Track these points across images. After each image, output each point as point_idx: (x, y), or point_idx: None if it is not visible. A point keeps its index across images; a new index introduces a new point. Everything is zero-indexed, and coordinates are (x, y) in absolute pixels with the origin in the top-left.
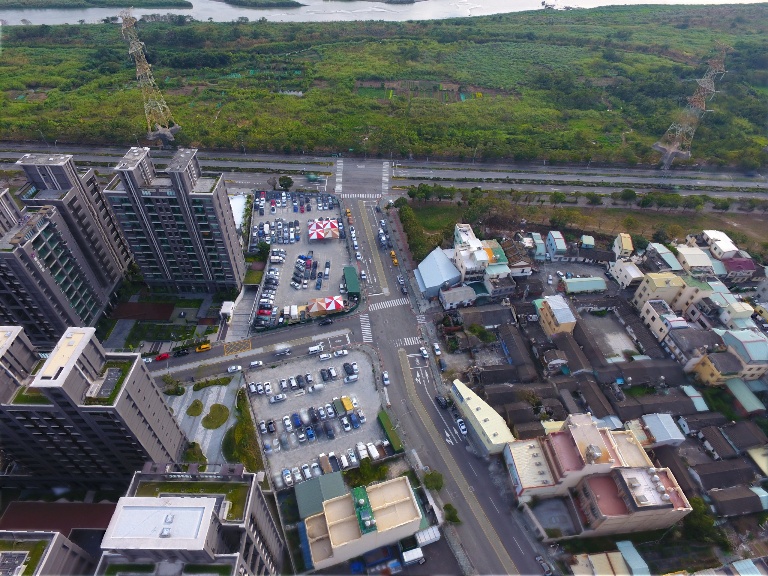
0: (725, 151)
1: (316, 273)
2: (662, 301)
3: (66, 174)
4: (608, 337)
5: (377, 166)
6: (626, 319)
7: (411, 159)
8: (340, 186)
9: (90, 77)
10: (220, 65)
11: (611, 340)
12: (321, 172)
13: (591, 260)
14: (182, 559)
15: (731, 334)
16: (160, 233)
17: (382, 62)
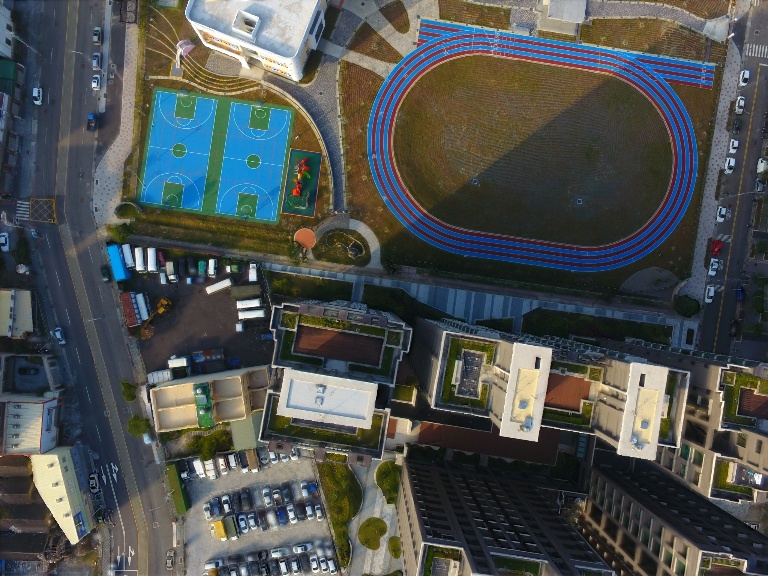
0: None
1: None
2: None
3: None
4: None
5: None
6: None
7: None
8: None
9: None
10: None
11: None
12: None
13: None
14: (323, 370)
15: None
16: None
17: None
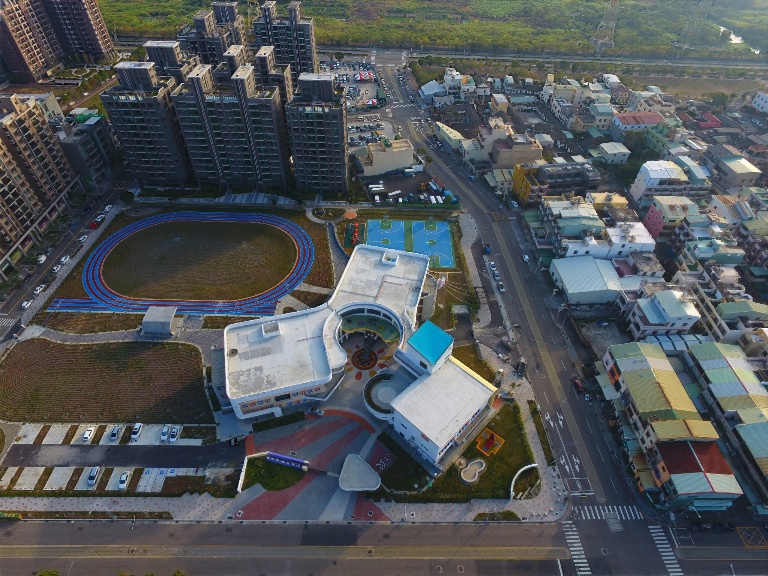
0: (645, 47)
1: (360, 94)
2: (563, 100)
3: (235, 12)
4: (529, 119)
5: (399, 52)
6: (541, 110)
7: (422, 49)
8: (374, 61)
9: (192, 9)
10: (284, 3)
11: (531, 120)
12: (361, 54)
13: (530, 92)
14: (322, 98)
15: (592, 104)
16: (278, 52)
17: (405, 1)
